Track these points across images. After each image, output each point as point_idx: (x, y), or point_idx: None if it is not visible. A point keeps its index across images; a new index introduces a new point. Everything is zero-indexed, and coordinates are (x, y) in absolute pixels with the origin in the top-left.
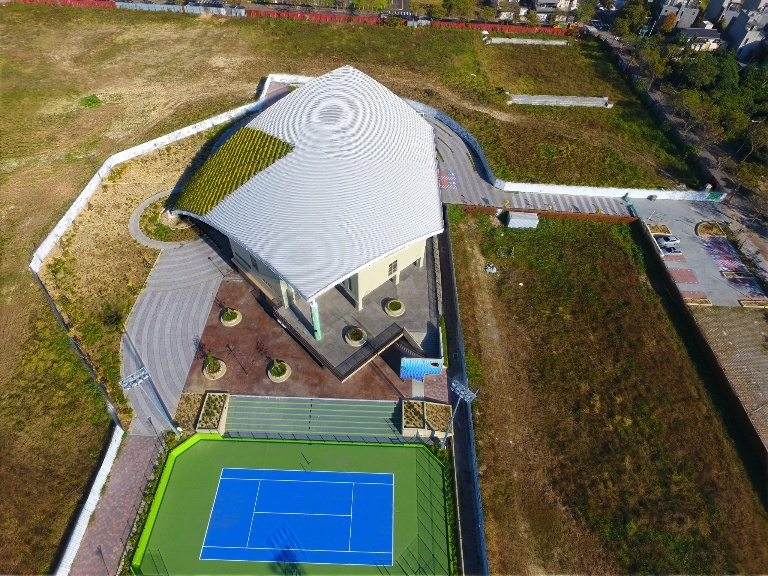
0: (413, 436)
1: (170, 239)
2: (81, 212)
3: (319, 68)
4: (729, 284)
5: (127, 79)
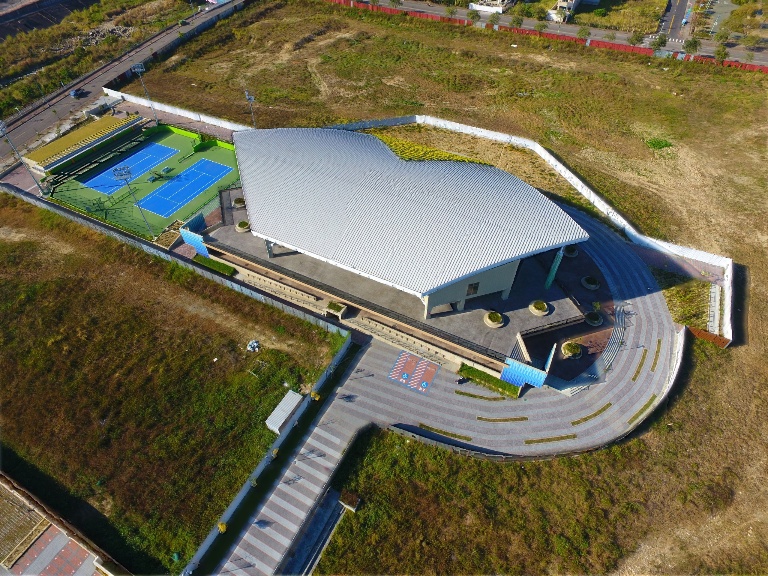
0: None
1: None
2: (472, 135)
3: None
4: None
5: (719, 165)
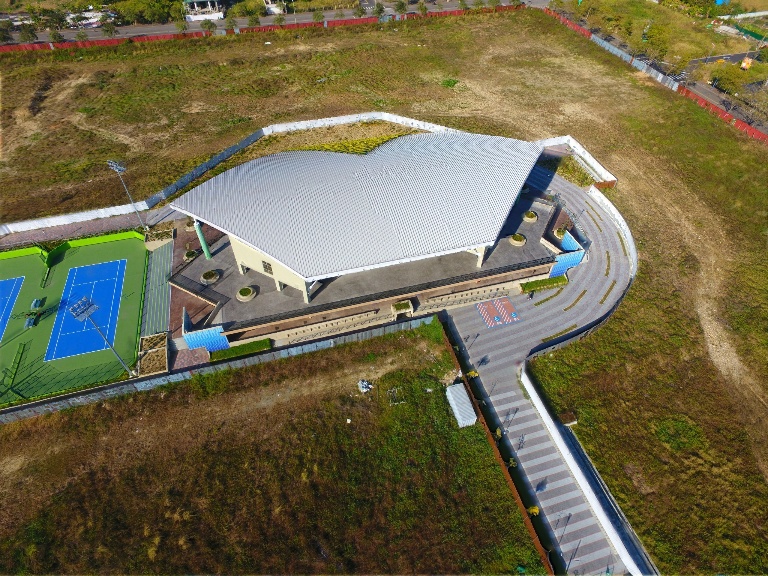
0: None
1: None
2: (324, 127)
3: (636, 163)
4: None
5: (494, 84)
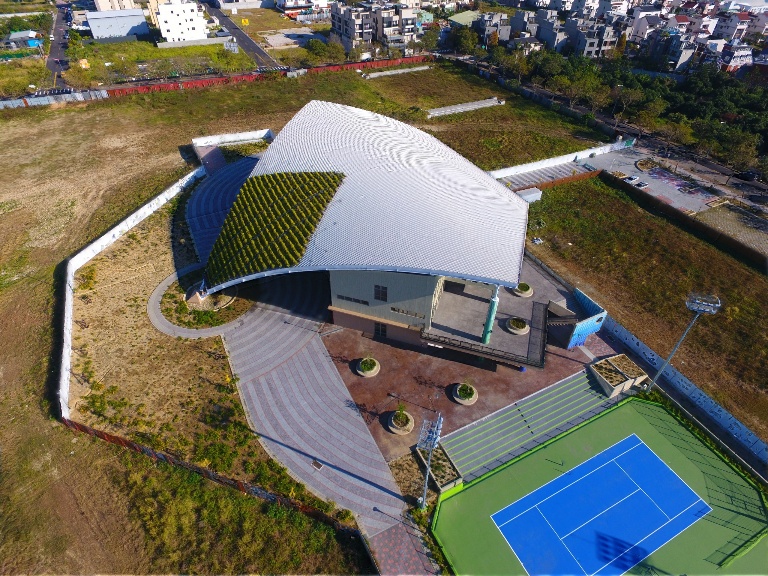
0: (617, 394)
1: (222, 321)
2: (74, 334)
3: (233, 126)
4: (691, 196)
5: (7, 184)
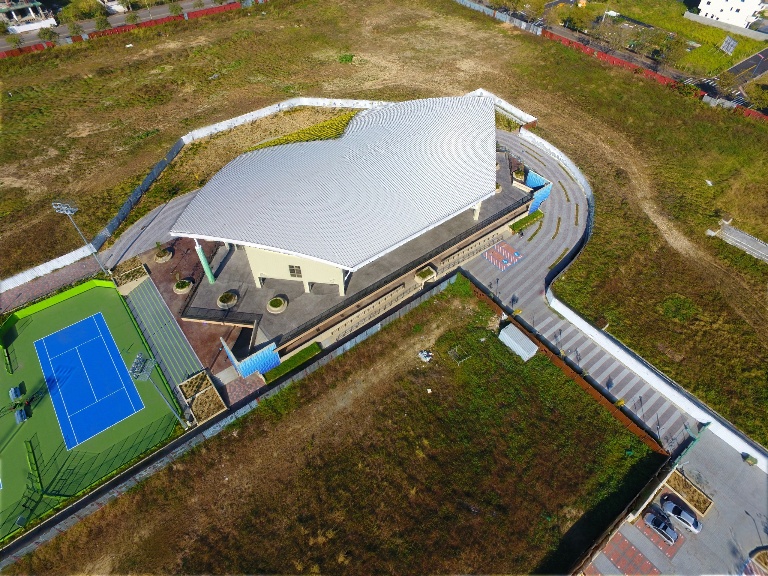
0: None
1: None
2: (246, 123)
3: (541, 103)
4: None
5: (387, 53)
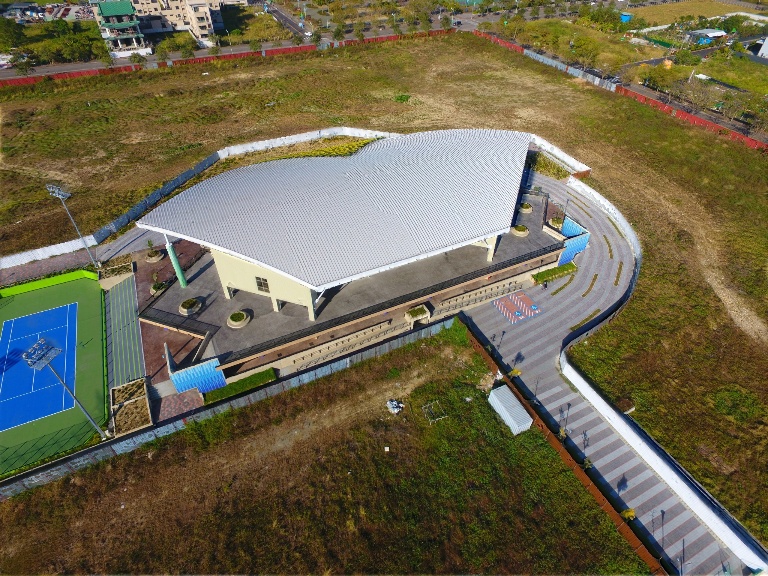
0: None
1: None
2: (284, 146)
3: (601, 155)
4: None
5: (445, 96)
